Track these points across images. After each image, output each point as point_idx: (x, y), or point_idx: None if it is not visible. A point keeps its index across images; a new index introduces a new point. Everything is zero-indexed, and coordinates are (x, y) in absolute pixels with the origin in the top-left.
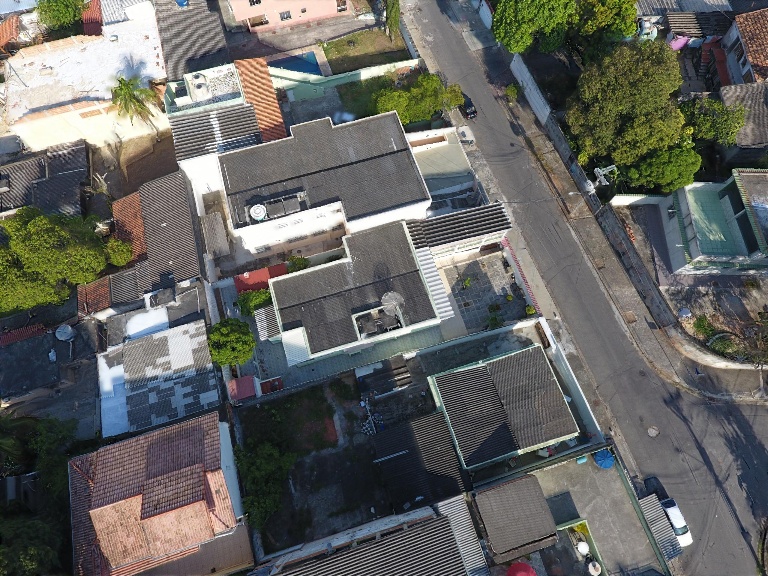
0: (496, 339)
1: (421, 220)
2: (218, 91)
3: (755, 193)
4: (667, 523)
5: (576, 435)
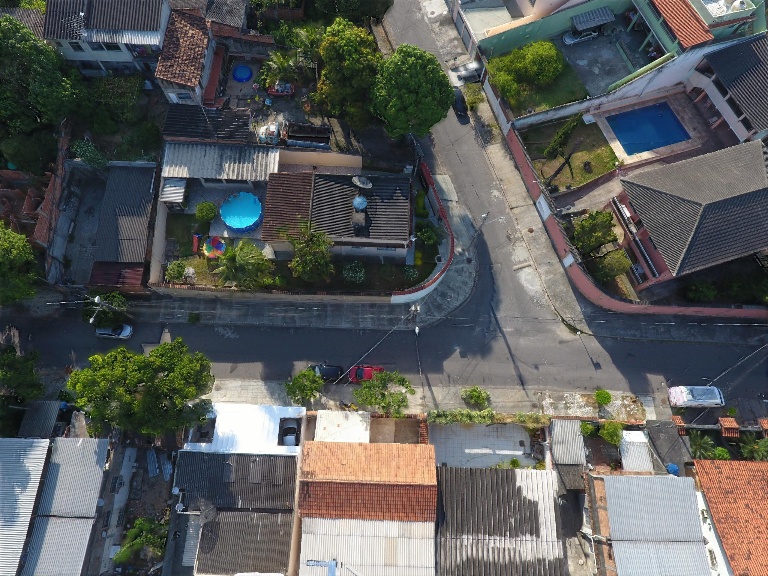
0: None
1: None
2: (716, 7)
3: None
4: None
5: None
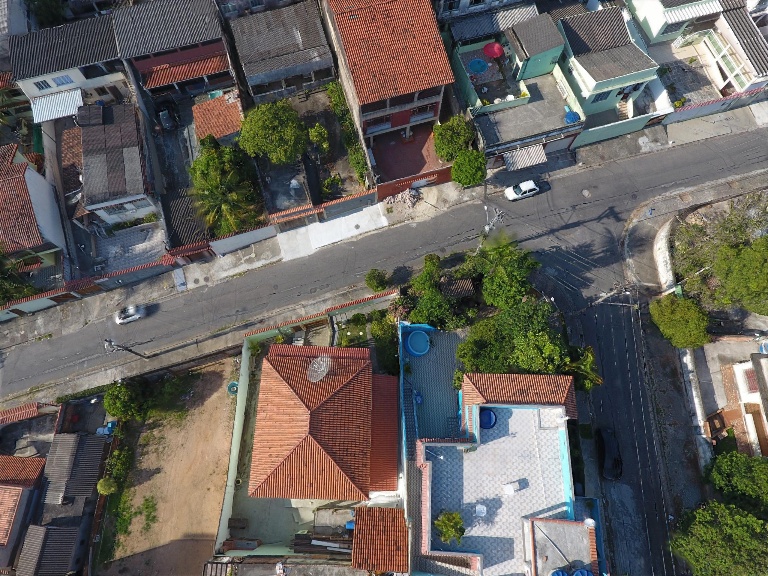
0: (645, 87)
1: (746, 9)
2: None
3: None
4: (527, 164)
5: (590, 93)
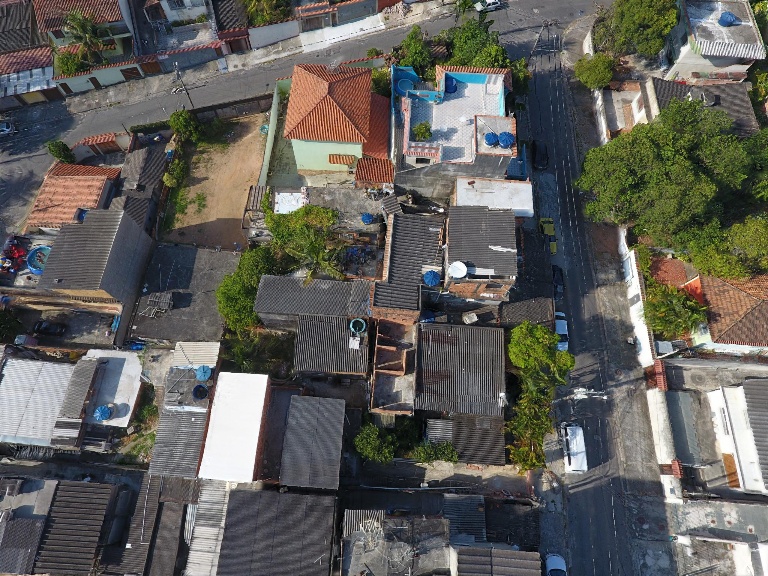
0: None
1: None
2: None
3: (730, 6)
4: None
5: None
